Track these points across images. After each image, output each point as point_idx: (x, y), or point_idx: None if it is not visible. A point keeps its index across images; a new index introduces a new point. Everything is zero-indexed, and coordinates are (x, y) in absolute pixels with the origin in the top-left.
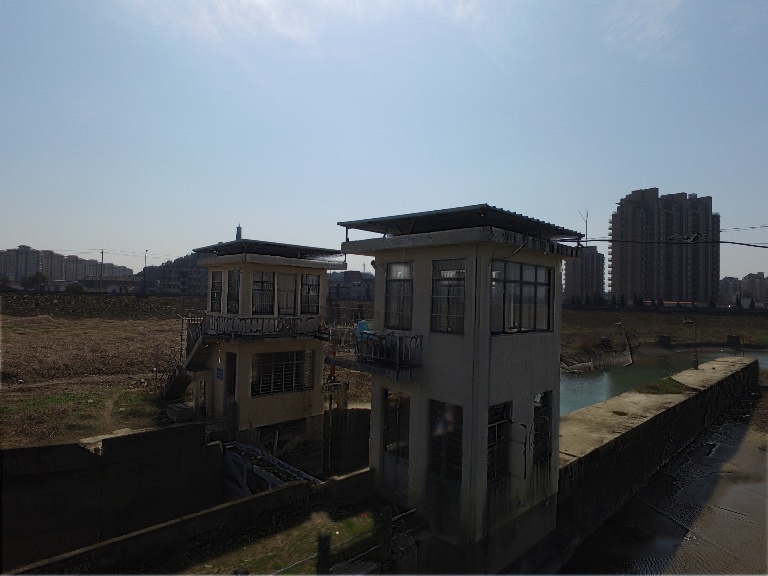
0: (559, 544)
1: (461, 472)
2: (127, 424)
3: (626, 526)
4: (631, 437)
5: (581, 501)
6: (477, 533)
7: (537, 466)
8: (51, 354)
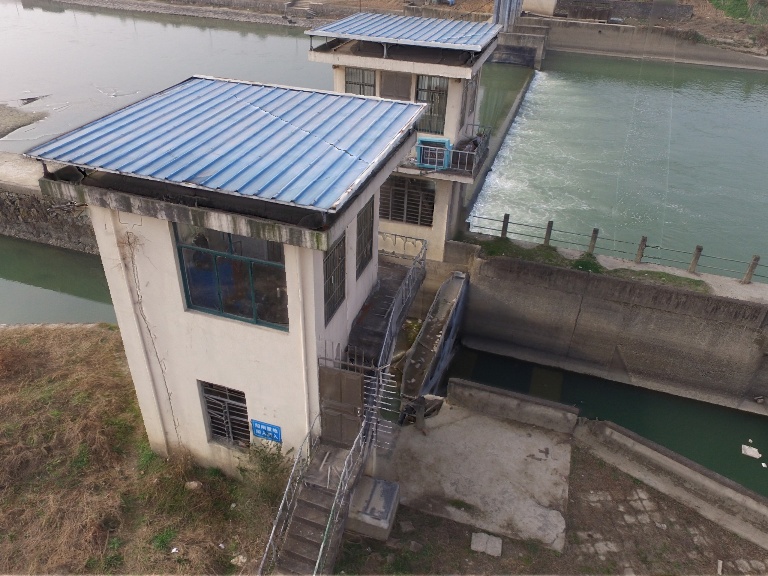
0: None
1: (462, 191)
2: (463, 567)
3: None
4: None
5: None
6: None
7: None
8: None
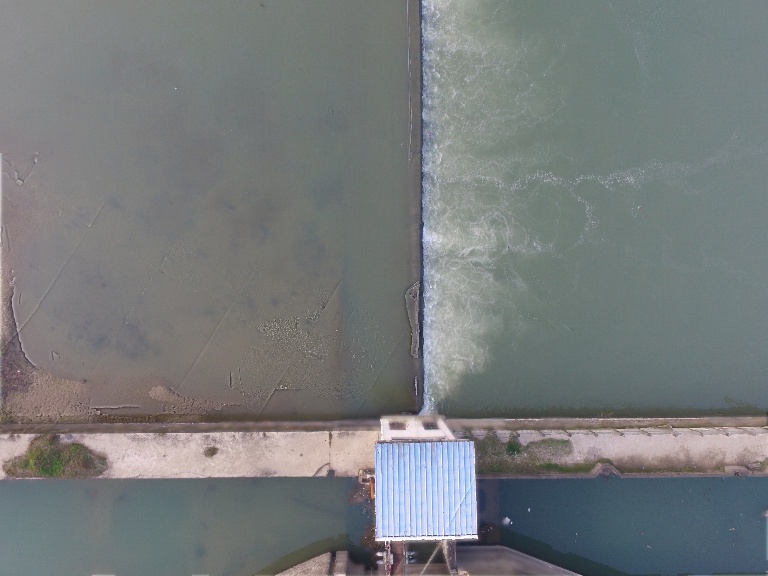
0: None
1: None
2: None
3: (297, 412)
4: None
5: None
6: None
7: None
8: None
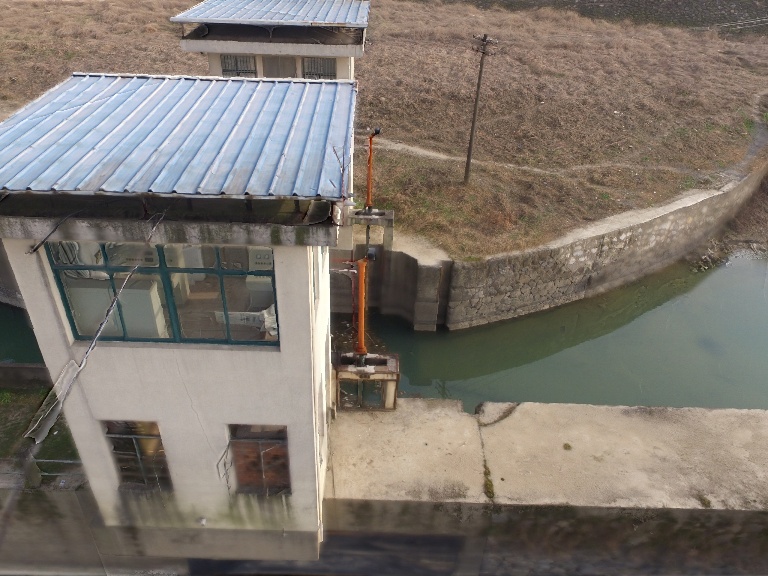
0: (408, 569)
1: None
2: None
3: None
4: (751, 521)
5: (493, 548)
6: (108, 519)
7: (248, 496)
8: None
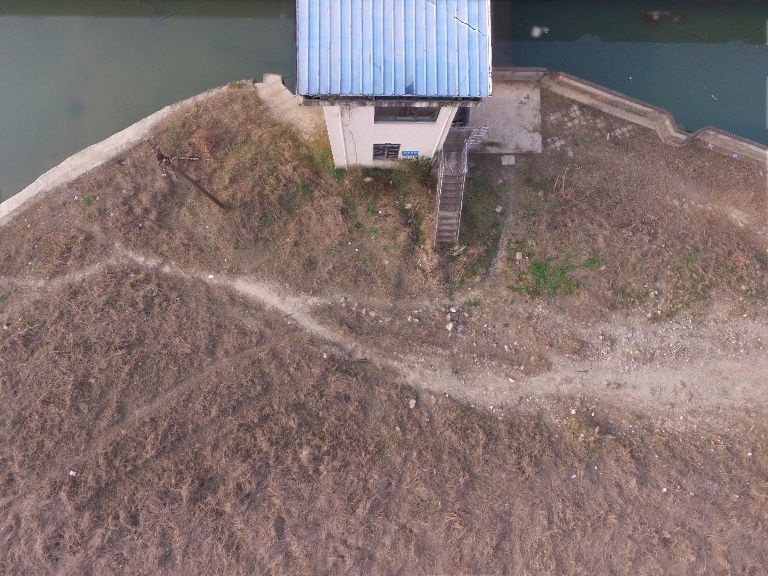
0: None
1: None
2: (501, 175)
3: None
4: None
5: None
6: None
7: None
8: (534, 568)
